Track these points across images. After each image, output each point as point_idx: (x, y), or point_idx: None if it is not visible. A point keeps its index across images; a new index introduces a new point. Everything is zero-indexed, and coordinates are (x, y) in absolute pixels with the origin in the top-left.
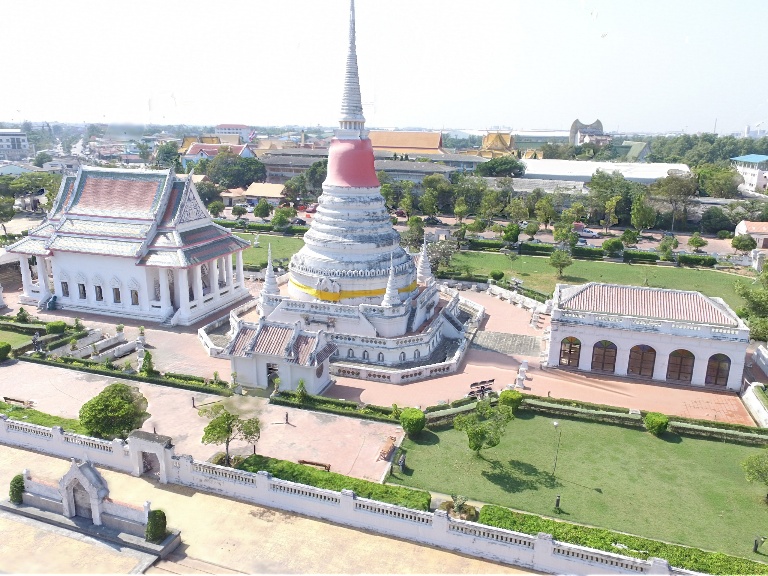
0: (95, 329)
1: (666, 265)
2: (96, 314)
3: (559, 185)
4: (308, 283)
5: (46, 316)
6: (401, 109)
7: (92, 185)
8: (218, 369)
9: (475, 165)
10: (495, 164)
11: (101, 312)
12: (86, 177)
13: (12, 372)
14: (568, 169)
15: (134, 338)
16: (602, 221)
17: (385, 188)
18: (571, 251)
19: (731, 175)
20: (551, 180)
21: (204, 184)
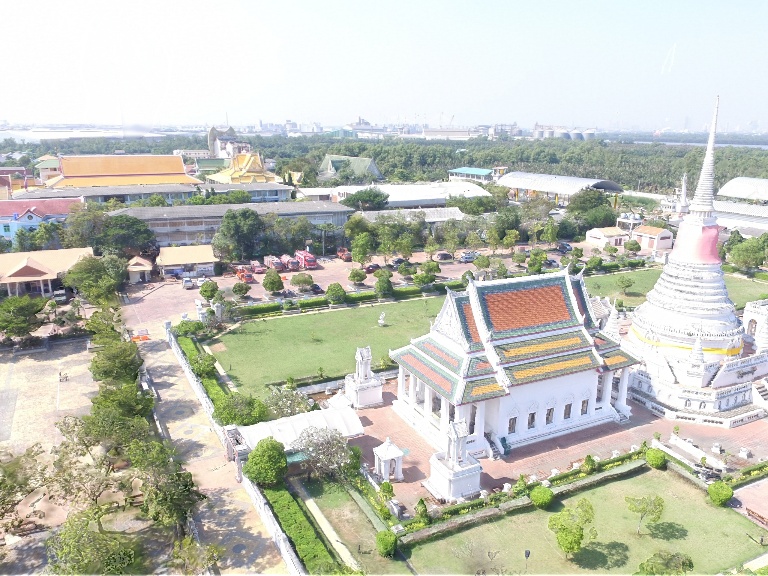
0: (634, 447)
1: (626, 270)
2: (550, 439)
3: (444, 212)
4: (716, 346)
5: (529, 461)
6: (152, 132)
7: (495, 302)
8: (764, 434)
9: (280, 193)
10: (371, 197)
11: (553, 435)
12: (484, 294)
13: (763, 503)
14: (406, 194)
15: (651, 442)
16: (530, 242)
17: (367, 237)
18: (573, 272)
19: (504, 189)
20: (434, 208)
21: (114, 260)
